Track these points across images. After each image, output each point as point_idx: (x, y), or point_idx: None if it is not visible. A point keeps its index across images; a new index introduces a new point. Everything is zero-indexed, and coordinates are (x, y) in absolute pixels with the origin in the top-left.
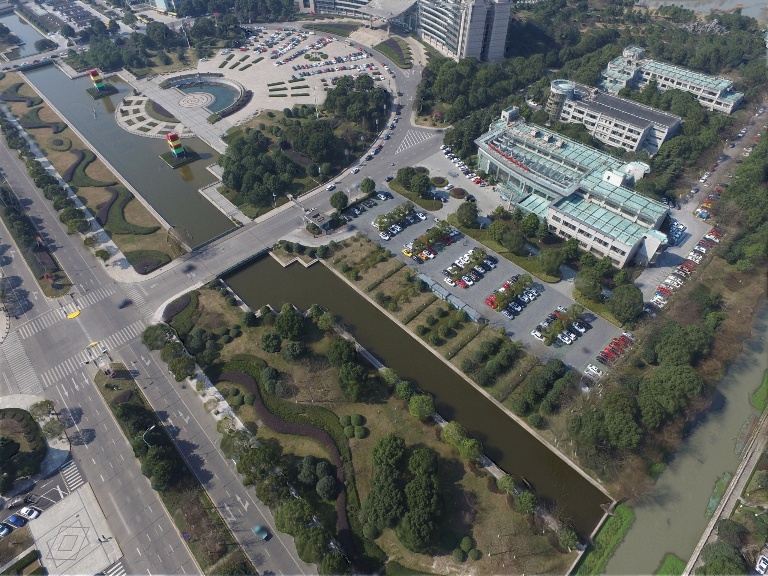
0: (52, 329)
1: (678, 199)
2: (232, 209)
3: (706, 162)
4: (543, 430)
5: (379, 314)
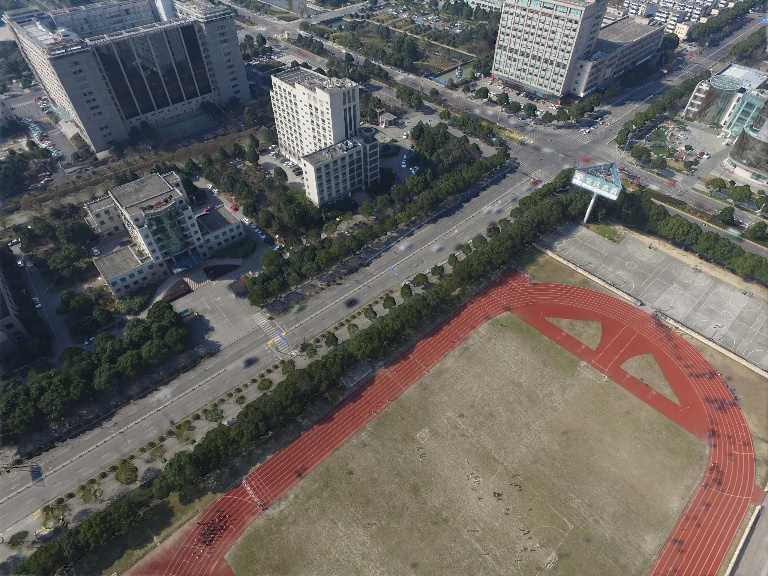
0: (257, 32)
1: None
2: (321, 8)
3: None
4: None
5: None
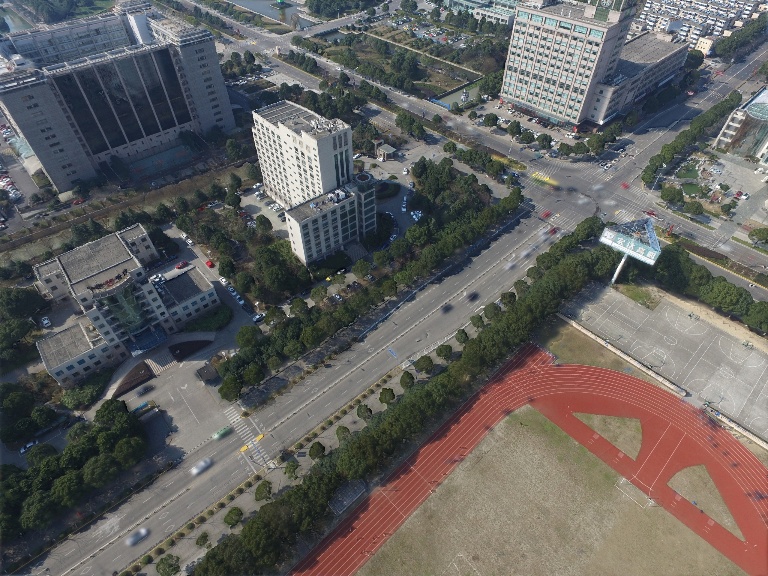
0: (246, 47)
1: None
2: (316, 19)
3: None
4: (460, 64)
5: (392, 49)
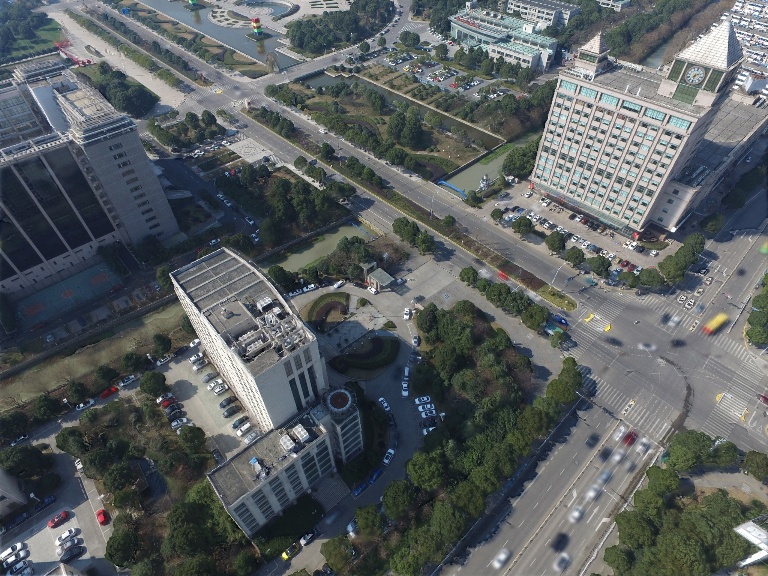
0: (210, 97)
1: (572, 49)
2: (298, 55)
3: (592, 30)
4: (475, 123)
5: (390, 97)
